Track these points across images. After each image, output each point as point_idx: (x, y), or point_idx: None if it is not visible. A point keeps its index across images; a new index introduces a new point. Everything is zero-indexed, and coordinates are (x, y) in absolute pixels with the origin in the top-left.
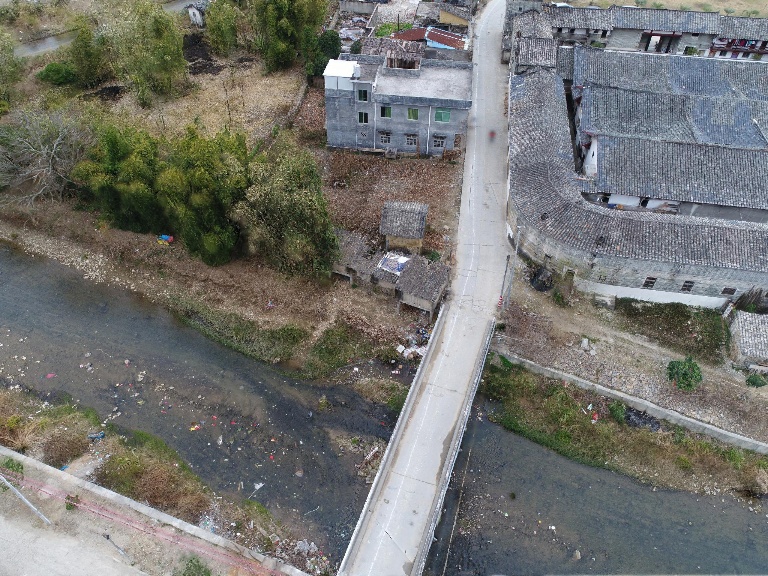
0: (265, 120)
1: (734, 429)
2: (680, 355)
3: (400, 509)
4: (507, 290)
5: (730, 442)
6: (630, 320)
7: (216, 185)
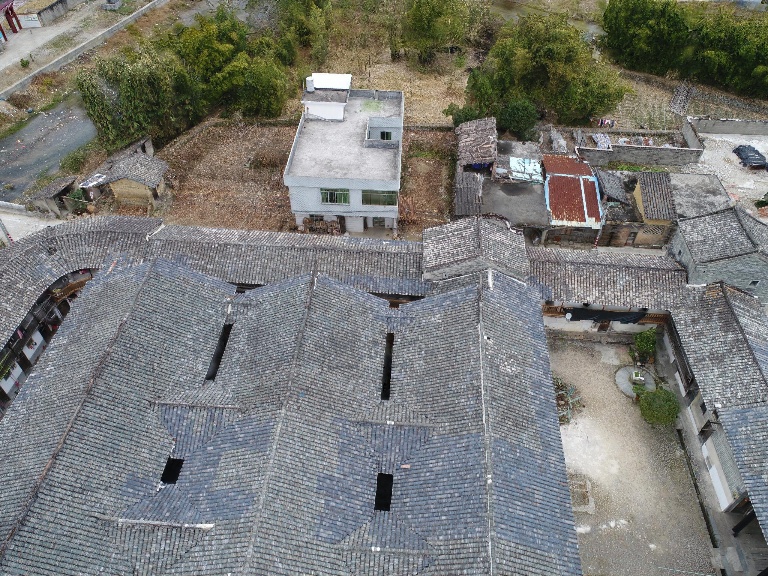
0: None
1: None
2: None
3: None
4: None
5: None
6: None
7: None
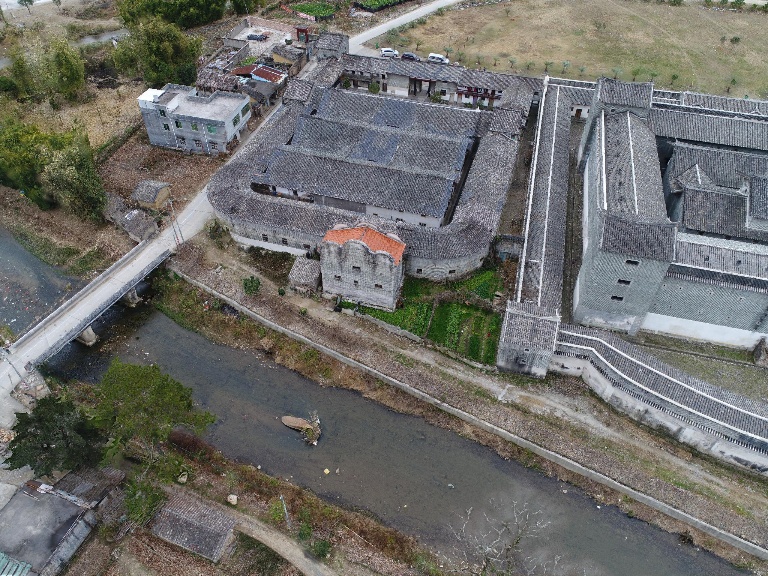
0: (126, 123)
1: (270, 318)
2: (267, 279)
3: (59, 329)
4: (193, 237)
5: (267, 325)
6: (254, 259)
7: (36, 162)
